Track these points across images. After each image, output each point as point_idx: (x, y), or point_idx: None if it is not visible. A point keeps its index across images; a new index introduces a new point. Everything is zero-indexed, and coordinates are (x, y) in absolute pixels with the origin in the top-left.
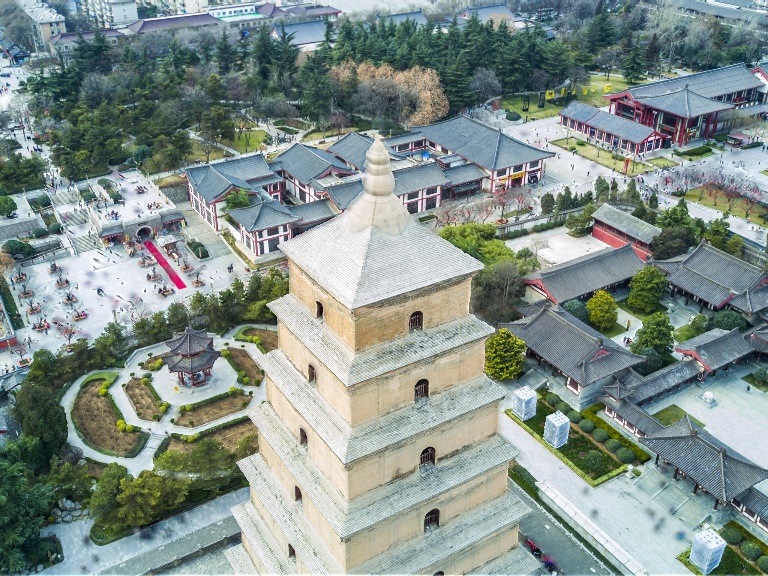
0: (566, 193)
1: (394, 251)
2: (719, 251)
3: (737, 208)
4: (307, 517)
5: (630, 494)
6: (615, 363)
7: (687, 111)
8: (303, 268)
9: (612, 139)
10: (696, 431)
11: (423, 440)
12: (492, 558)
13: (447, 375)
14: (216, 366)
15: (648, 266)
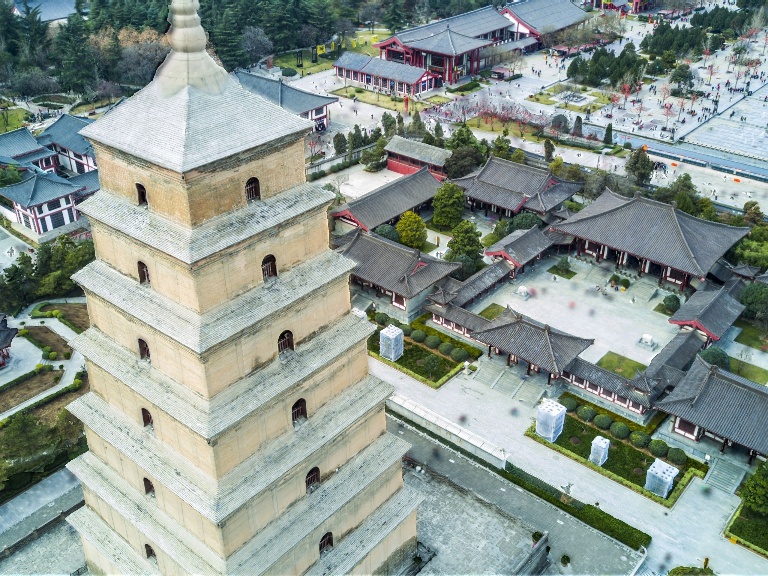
0: (356, 131)
1: (217, 111)
2: (507, 161)
3: (512, 131)
4: (161, 439)
5: (471, 388)
6: (434, 273)
7: (452, 49)
8: (115, 146)
9: (388, 83)
10: (521, 316)
11: (278, 323)
12: (364, 447)
13: (293, 249)
14: (14, 347)
15: (447, 183)
